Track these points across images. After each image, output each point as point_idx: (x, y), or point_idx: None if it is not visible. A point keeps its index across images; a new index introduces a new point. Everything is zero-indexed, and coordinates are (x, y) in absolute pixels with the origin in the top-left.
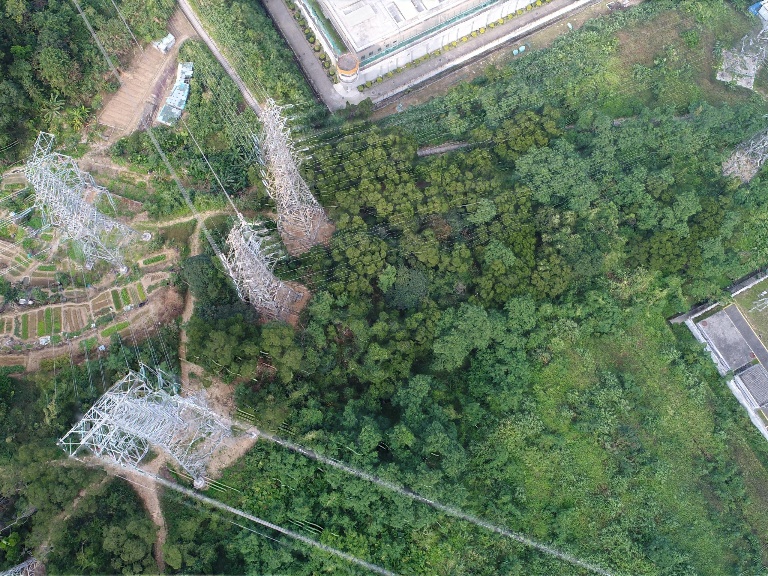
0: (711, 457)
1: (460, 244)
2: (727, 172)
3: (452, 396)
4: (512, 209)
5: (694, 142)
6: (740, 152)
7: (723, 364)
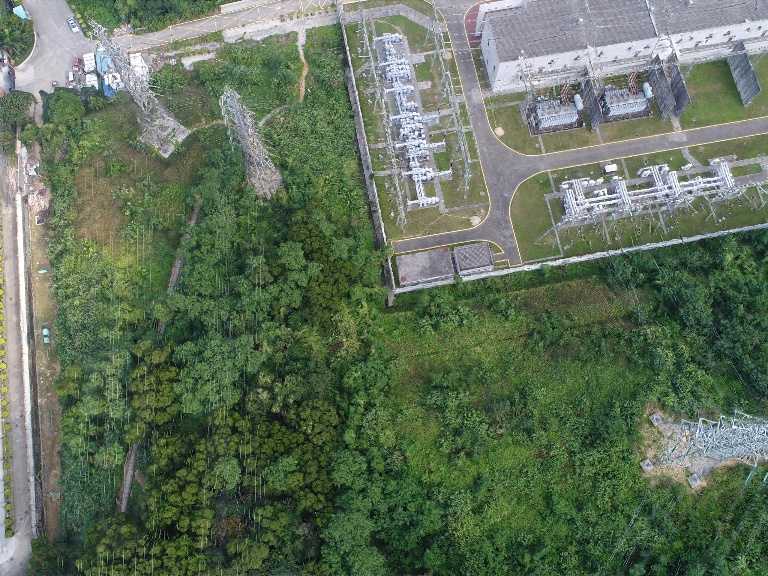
0: (528, 331)
1: (257, 515)
2: (266, 194)
3: (407, 570)
4: (236, 439)
5: (227, 214)
6: (253, 177)
7: (445, 279)
